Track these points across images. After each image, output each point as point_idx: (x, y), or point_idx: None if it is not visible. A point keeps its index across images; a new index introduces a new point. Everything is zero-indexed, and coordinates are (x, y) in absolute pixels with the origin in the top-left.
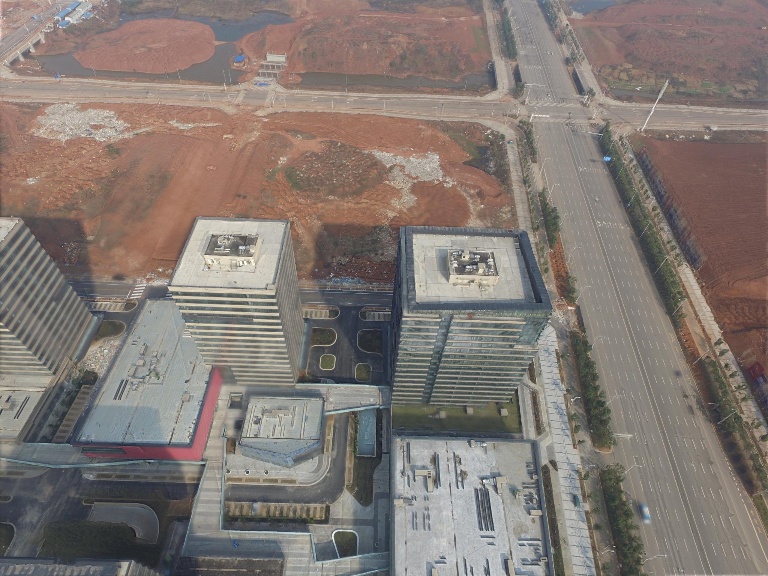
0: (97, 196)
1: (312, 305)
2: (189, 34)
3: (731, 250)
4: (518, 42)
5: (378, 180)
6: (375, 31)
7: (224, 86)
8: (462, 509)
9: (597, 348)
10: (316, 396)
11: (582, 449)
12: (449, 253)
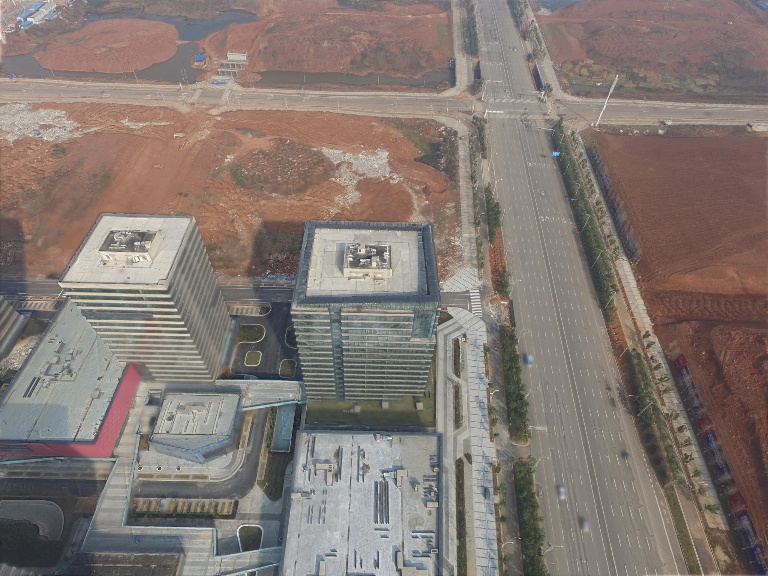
0: (38, 195)
1: (244, 302)
2: (152, 34)
3: (670, 243)
4: (482, 39)
5: (324, 177)
6: (337, 29)
7: (180, 85)
8: (360, 502)
9: (526, 342)
10: (235, 392)
11: (499, 442)
12: (346, 247)
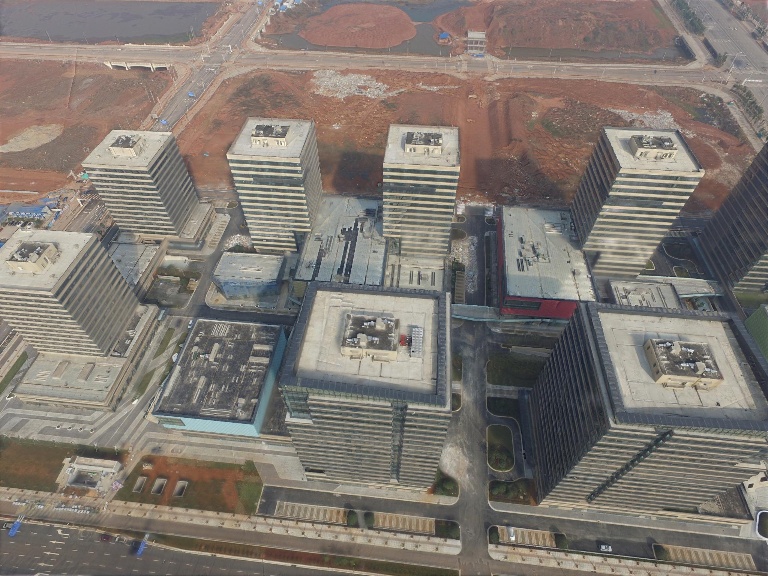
0: None
1: None
2: (391, 16)
3: None
4: None
5: None
6: (563, 10)
7: (446, 57)
8: None
9: None
10: None
11: None
12: None
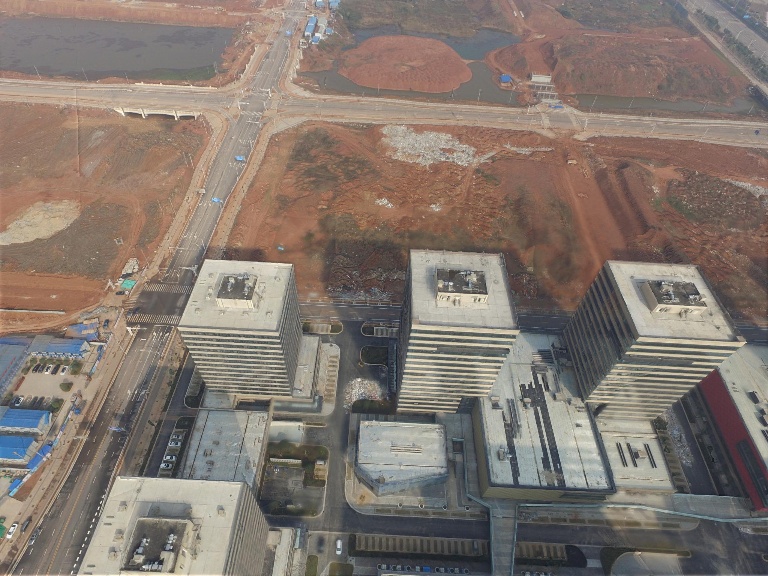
0: (510, 225)
1: None
2: (440, 52)
3: None
4: None
5: (761, 212)
6: (628, 53)
7: (522, 108)
8: None
9: None
10: None
11: None
12: None
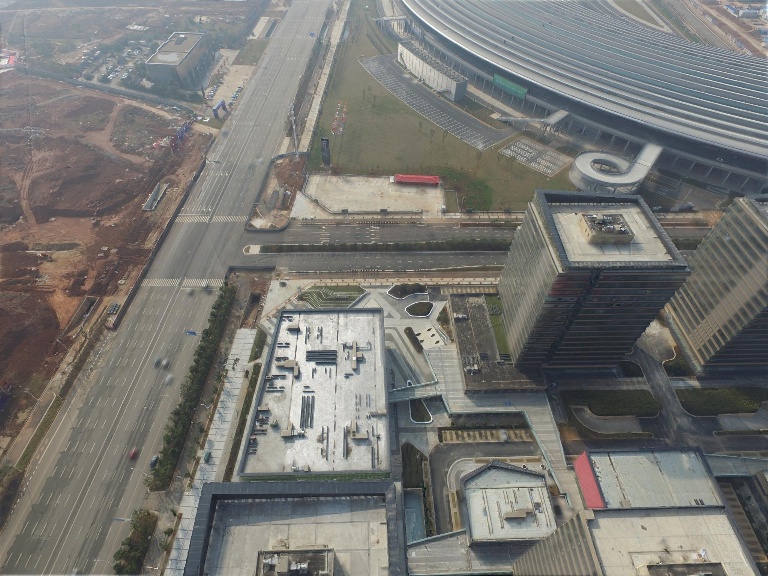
0: None
1: None
2: None
3: None
4: None
5: None
6: None
7: None
8: (327, 411)
9: None
10: (483, 555)
11: None
12: None
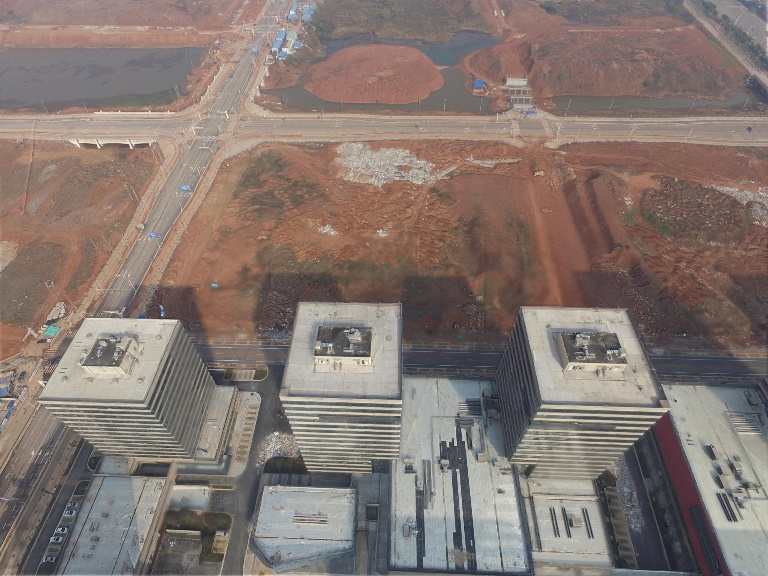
0: (461, 249)
1: None
2: (411, 60)
3: None
4: None
5: (747, 221)
6: (612, 48)
7: (491, 116)
8: None
9: None
10: None
11: None
12: None
